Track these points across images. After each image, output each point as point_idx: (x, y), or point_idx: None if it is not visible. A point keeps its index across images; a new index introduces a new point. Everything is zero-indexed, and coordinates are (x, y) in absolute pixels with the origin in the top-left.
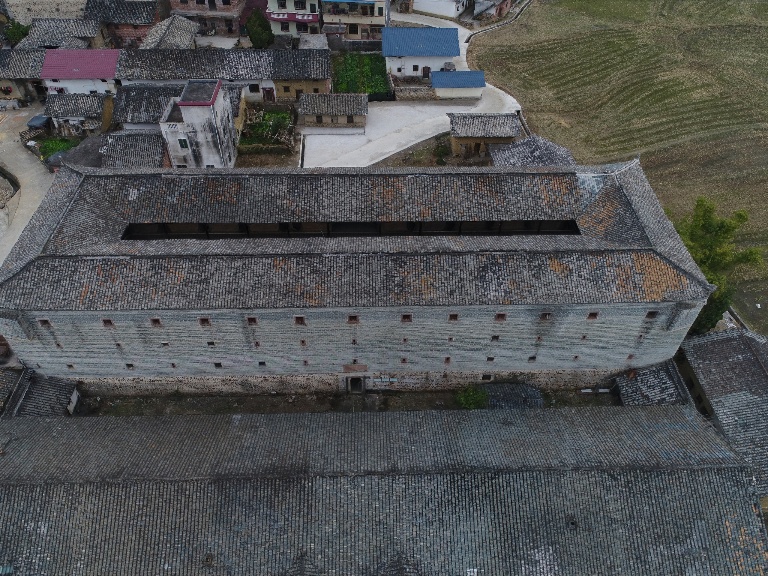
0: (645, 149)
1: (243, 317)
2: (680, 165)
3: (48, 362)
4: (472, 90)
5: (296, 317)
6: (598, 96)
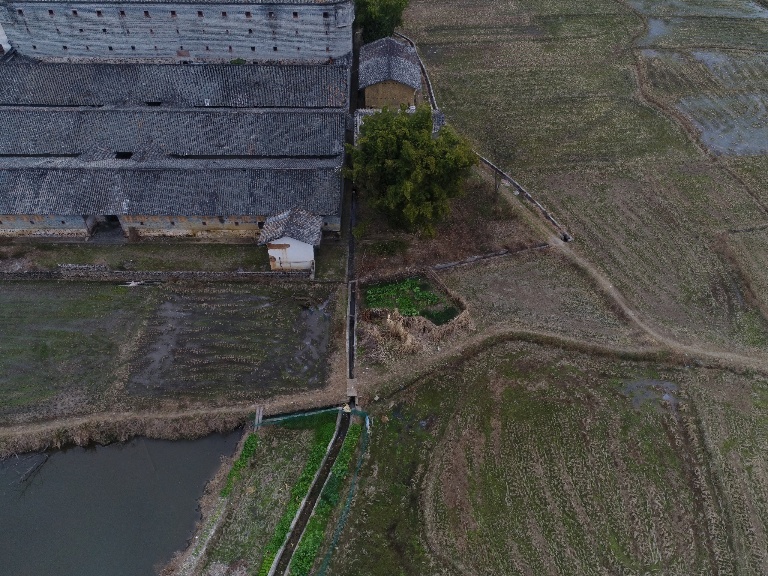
0: None
1: (118, 10)
2: None
3: (23, 43)
4: None
5: (144, 11)
6: None
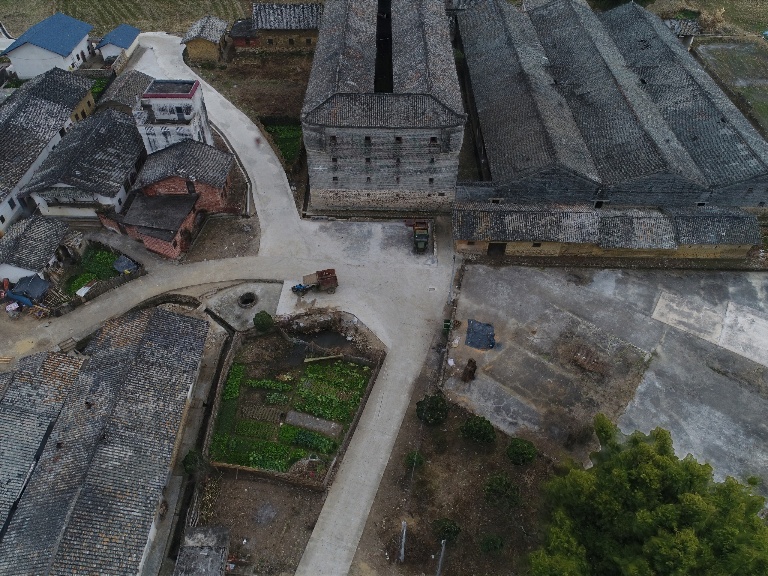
0: (238, 5)
1: None
2: (257, 0)
3: None
4: (135, 39)
5: None
6: (161, 7)
